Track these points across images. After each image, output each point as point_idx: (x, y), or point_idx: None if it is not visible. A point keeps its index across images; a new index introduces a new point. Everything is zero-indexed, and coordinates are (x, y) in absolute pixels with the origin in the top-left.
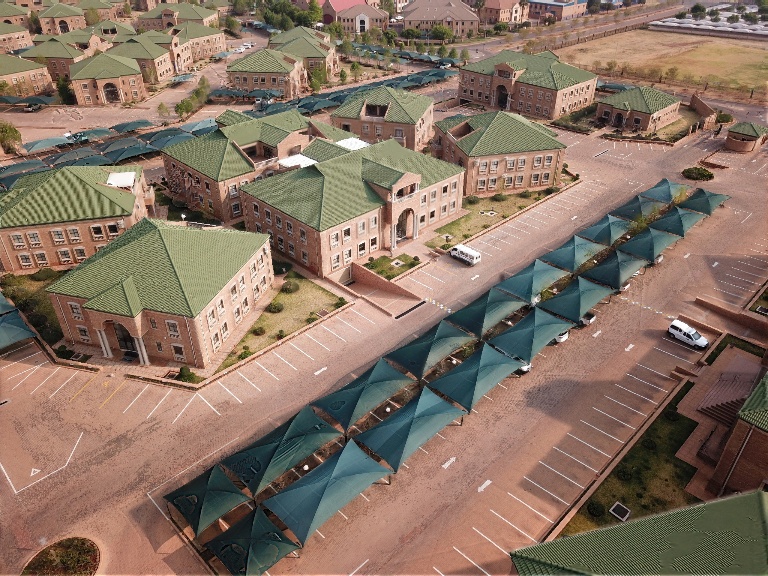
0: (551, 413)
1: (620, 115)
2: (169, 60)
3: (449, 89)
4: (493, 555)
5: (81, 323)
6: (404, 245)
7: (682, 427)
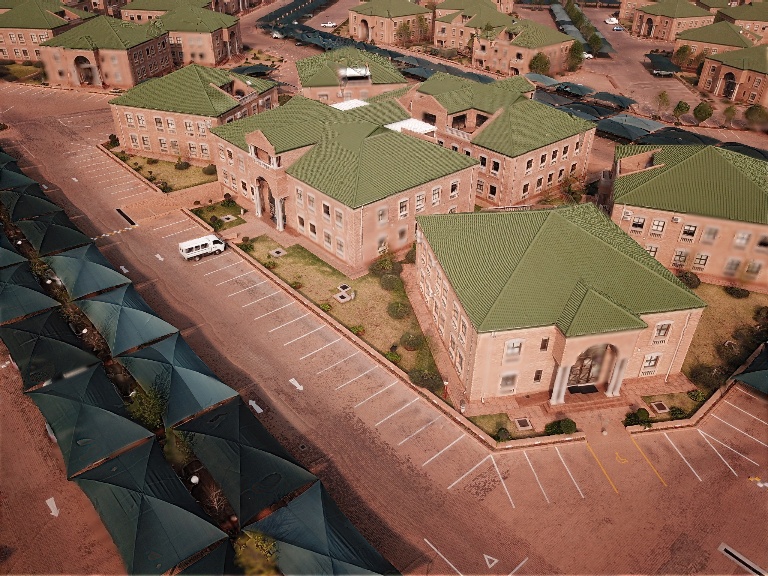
0: None
1: None
2: None
3: None
4: None
5: None
6: (265, 222)
7: None
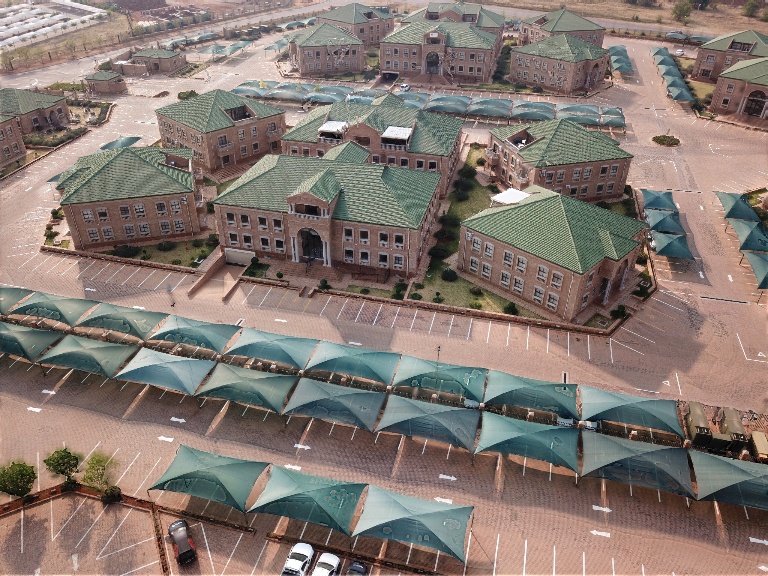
0: None
1: None
2: None
3: None
4: None
5: None
6: None
7: None
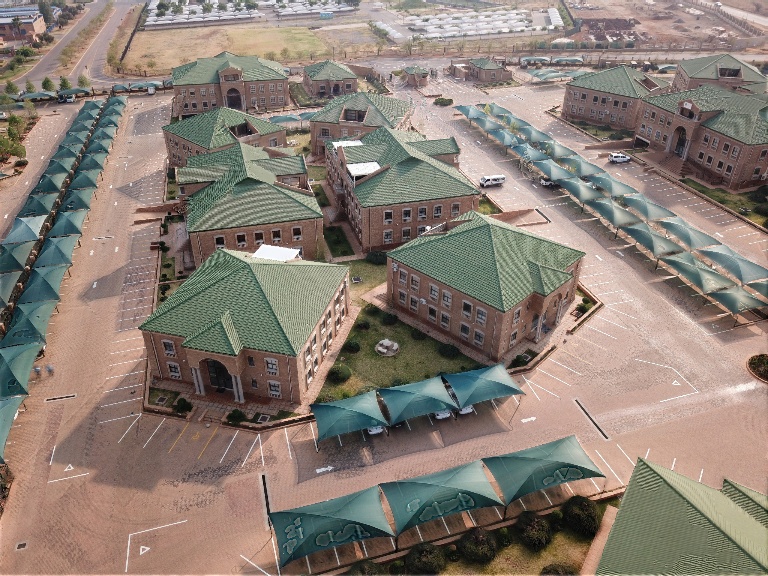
0: (667, 206)
1: (334, 86)
2: None
3: (138, 114)
4: (767, 243)
5: (514, 328)
6: None
7: None
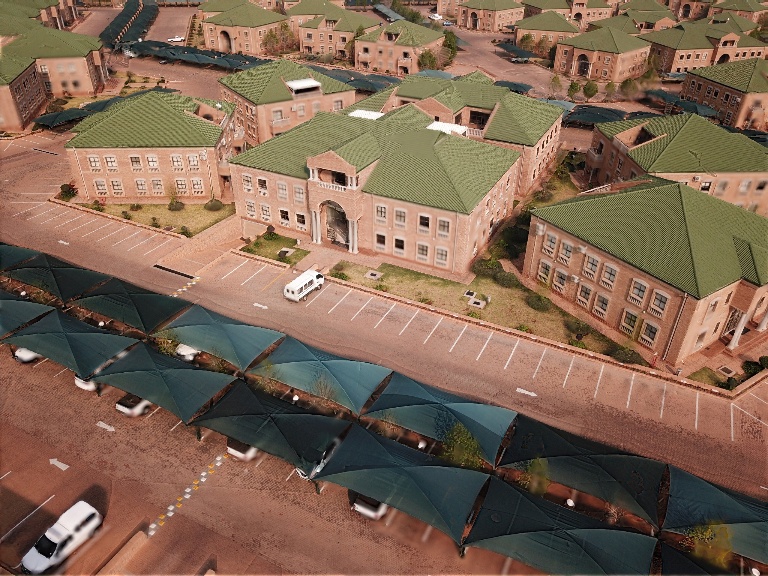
0: None
1: None
2: (708, 58)
3: None
4: None
5: None
6: (330, 248)
7: None
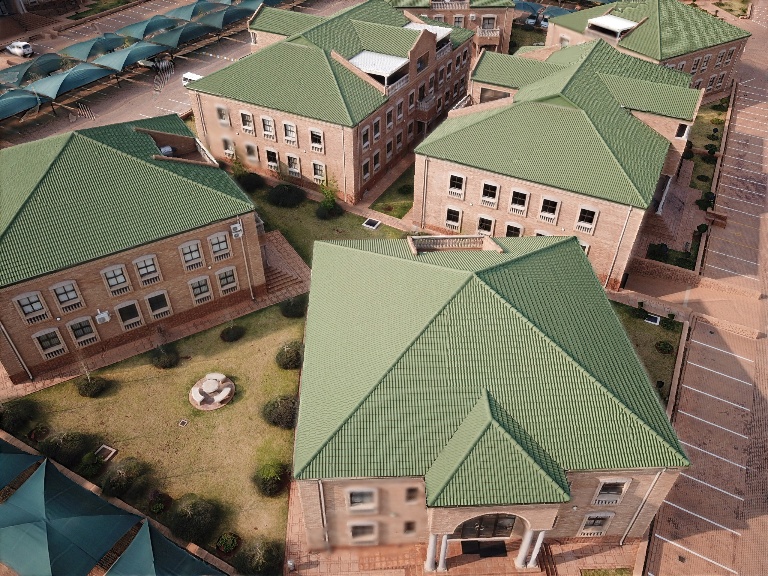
0: None
1: None
2: None
3: None
4: None
5: None
6: None
7: (78, 16)
